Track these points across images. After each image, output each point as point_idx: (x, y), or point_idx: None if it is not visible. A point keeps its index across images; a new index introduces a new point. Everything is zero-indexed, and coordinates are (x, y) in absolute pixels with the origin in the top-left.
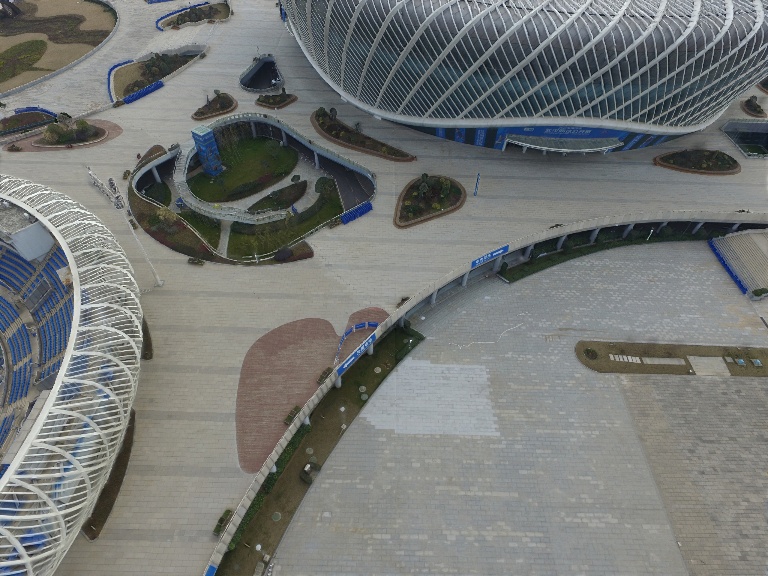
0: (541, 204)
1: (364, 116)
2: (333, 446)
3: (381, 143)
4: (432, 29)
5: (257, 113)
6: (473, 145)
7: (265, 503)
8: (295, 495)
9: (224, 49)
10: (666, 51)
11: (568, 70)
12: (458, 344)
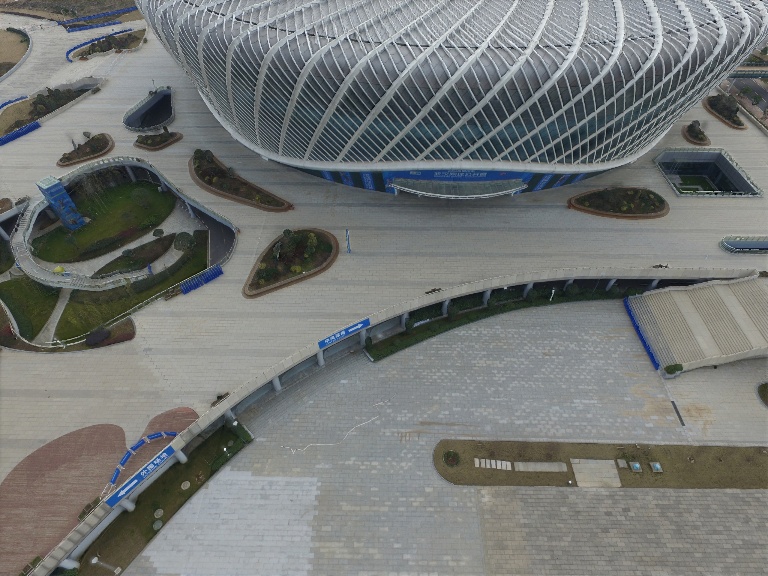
0: (423, 262)
1: (250, 156)
2: None
3: (257, 189)
4: (274, 67)
5: (129, 157)
6: (363, 189)
7: None
8: None
9: (122, 82)
10: (543, 87)
11: (433, 111)
12: (292, 447)
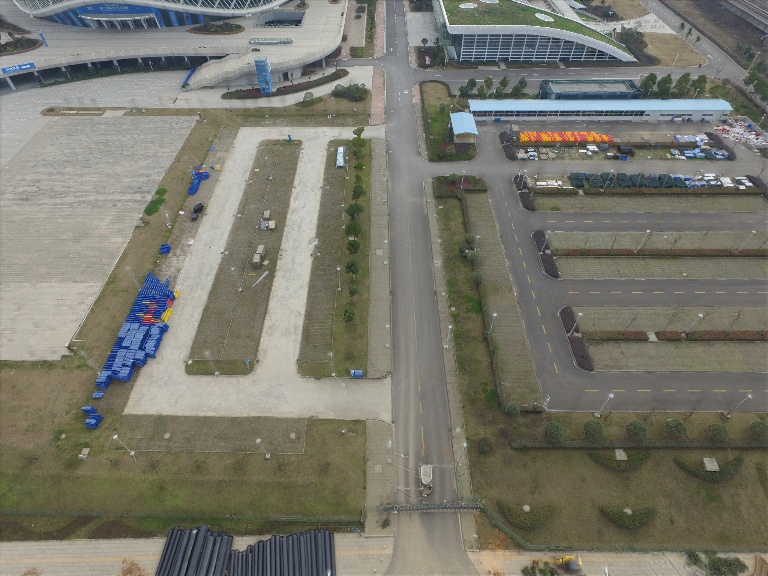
0: (83, 49)
1: (24, 16)
2: None
3: None
4: None
5: None
6: (78, 26)
7: None
8: None
9: None
10: None
11: None
12: None
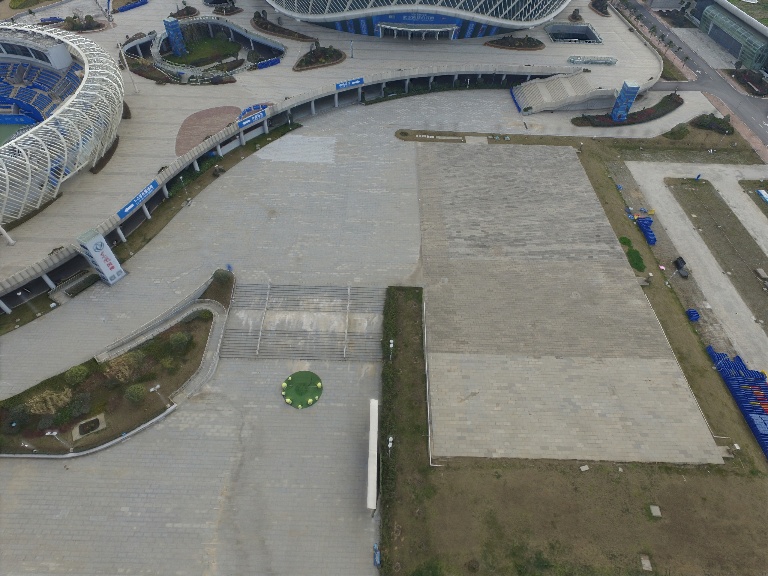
0: (395, 62)
1: (289, 20)
2: (234, 164)
3: (296, 32)
4: None
5: (212, 16)
6: (361, 34)
7: (192, 183)
8: (209, 180)
9: None
10: None
11: None
12: (322, 129)
